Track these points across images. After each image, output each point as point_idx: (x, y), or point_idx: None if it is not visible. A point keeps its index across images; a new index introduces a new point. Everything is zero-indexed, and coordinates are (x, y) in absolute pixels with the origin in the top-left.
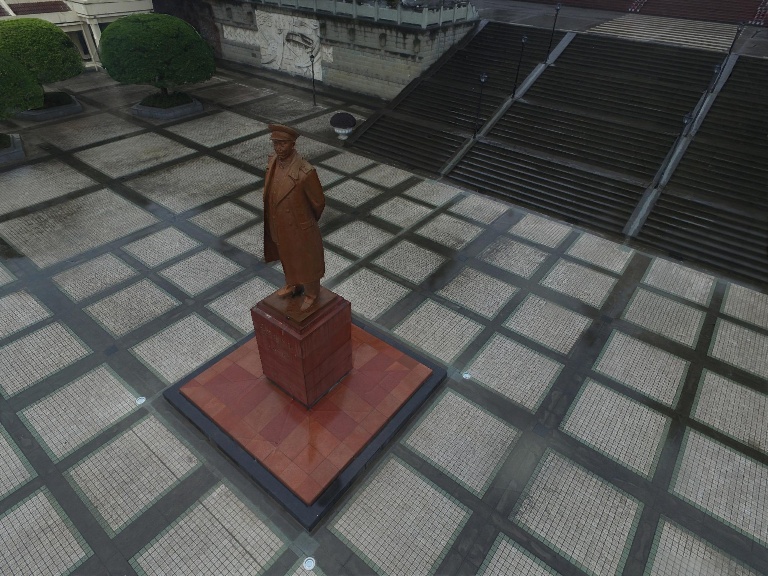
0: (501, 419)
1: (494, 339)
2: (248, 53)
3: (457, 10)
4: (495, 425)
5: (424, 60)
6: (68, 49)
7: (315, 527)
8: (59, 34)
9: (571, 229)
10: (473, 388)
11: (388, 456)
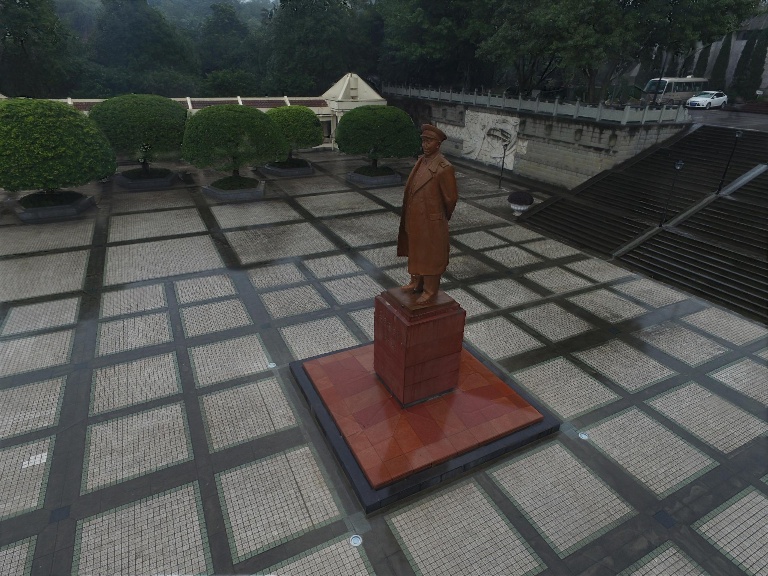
0: (614, 490)
1: (629, 412)
2: (452, 145)
3: (665, 111)
4: (604, 493)
5: (619, 154)
6: (316, 127)
7: (373, 512)
8: (313, 117)
9: None
10: (588, 450)
11: (468, 479)
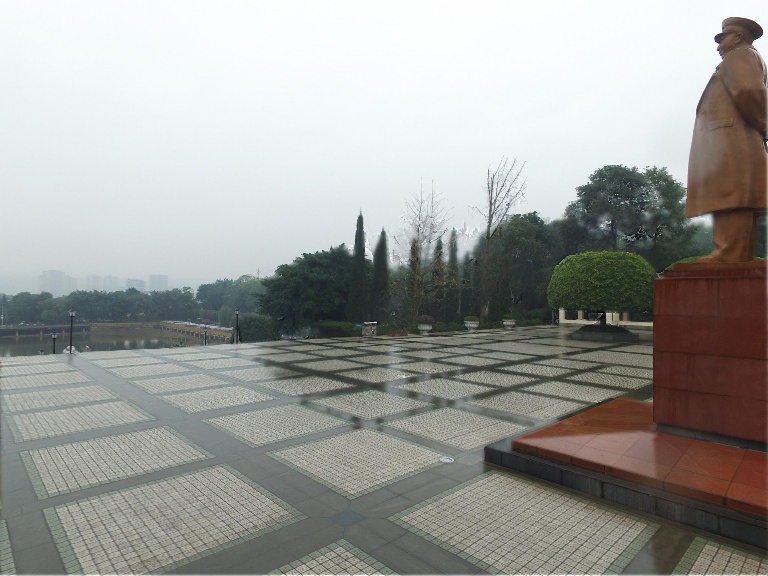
0: None
1: None
2: None
3: None
4: None
5: None
6: None
7: (491, 463)
8: None
9: None
10: None
11: (649, 520)
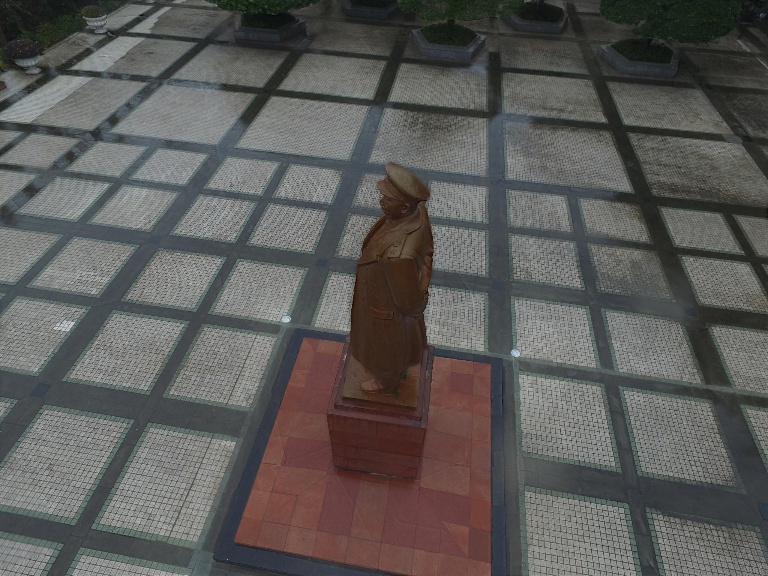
0: None
1: None
2: None
3: None
4: None
5: None
6: None
7: (223, 563)
8: None
9: None
10: None
11: None
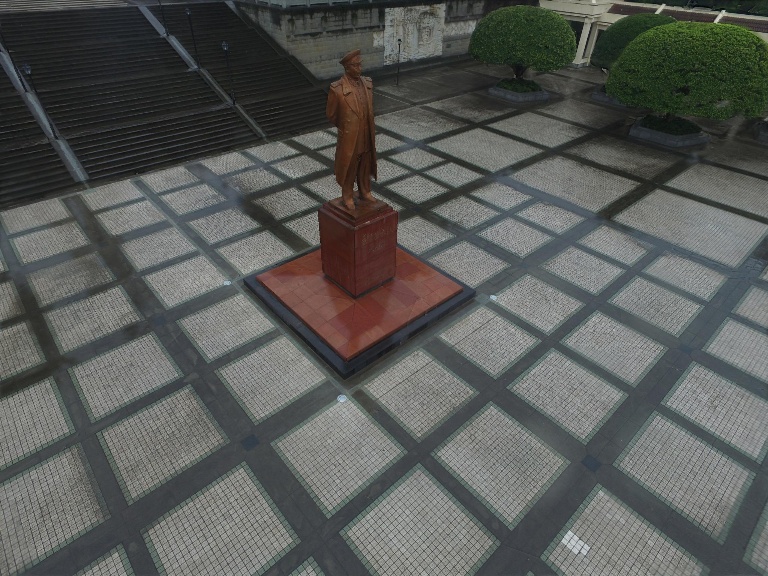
0: (407, 219)
1: None
2: None
3: None
4: (411, 222)
5: None
6: None
7: None
8: None
9: (237, 152)
10: None
11: None
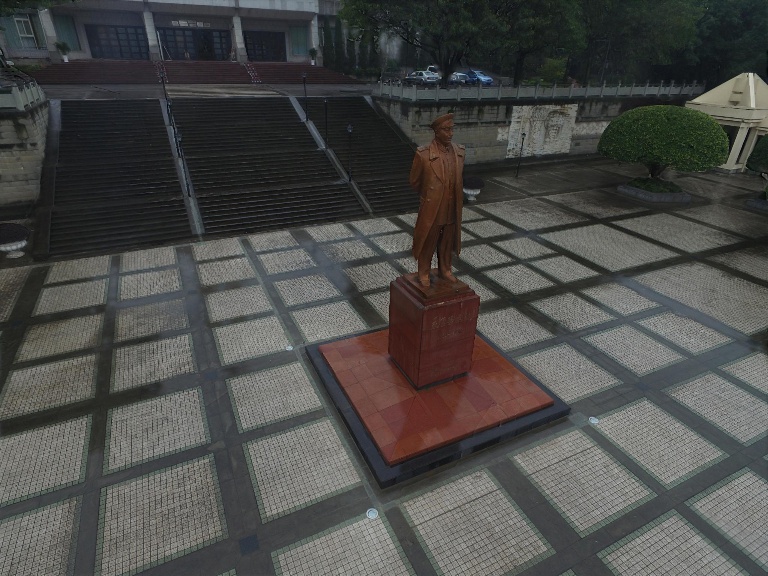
0: (500, 309)
1: None
2: None
3: (32, 90)
4: (504, 313)
5: (38, 146)
6: None
7: None
8: None
9: (341, 224)
10: None
11: None
